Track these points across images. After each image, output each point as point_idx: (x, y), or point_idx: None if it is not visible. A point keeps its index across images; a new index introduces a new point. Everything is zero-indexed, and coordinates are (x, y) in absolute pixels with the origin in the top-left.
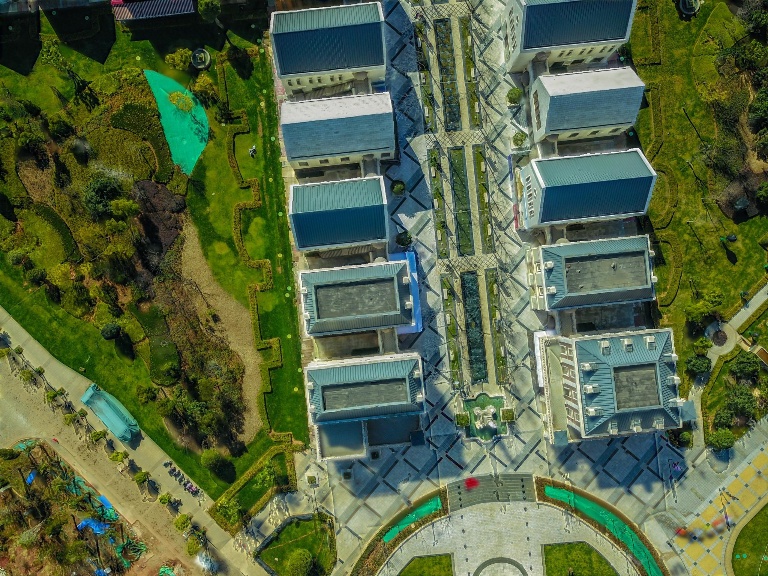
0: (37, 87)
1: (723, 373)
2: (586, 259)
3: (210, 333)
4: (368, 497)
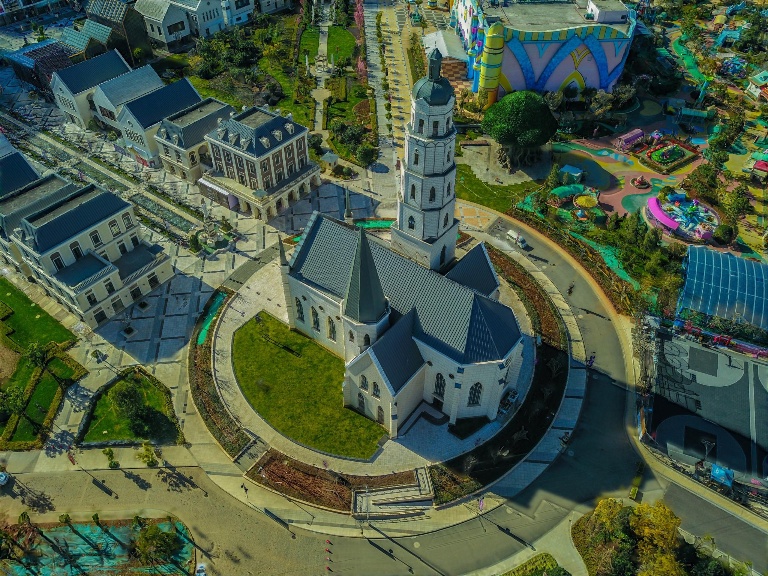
0: None
1: (336, 144)
2: (181, 116)
3: None
4: (161, 333)
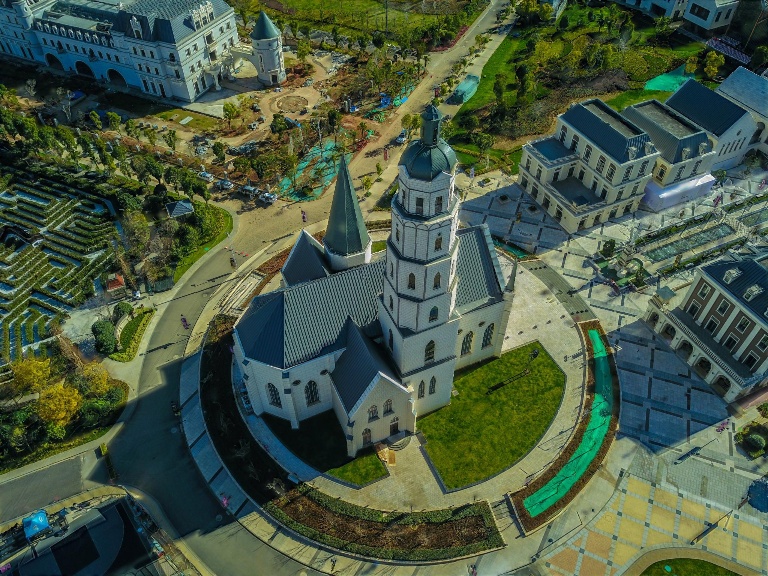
0: (633, 35)
1: None
2: None
3: (553, 115)
4: (493, 216)
